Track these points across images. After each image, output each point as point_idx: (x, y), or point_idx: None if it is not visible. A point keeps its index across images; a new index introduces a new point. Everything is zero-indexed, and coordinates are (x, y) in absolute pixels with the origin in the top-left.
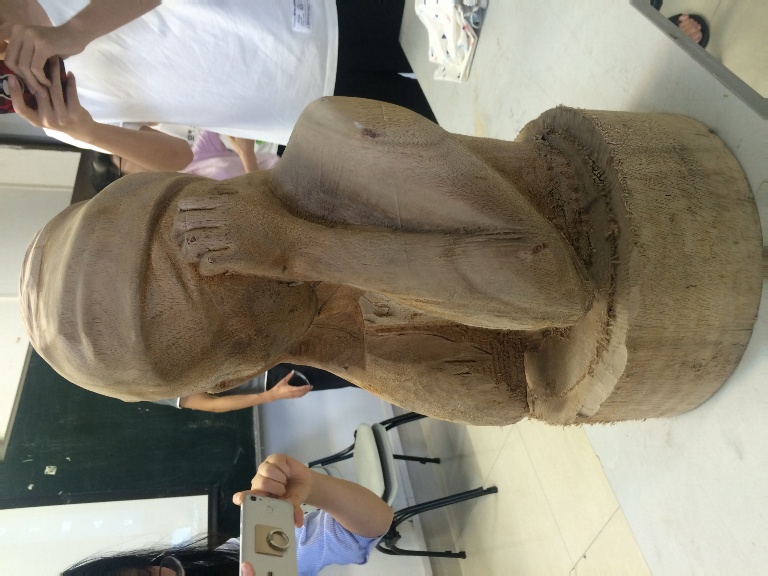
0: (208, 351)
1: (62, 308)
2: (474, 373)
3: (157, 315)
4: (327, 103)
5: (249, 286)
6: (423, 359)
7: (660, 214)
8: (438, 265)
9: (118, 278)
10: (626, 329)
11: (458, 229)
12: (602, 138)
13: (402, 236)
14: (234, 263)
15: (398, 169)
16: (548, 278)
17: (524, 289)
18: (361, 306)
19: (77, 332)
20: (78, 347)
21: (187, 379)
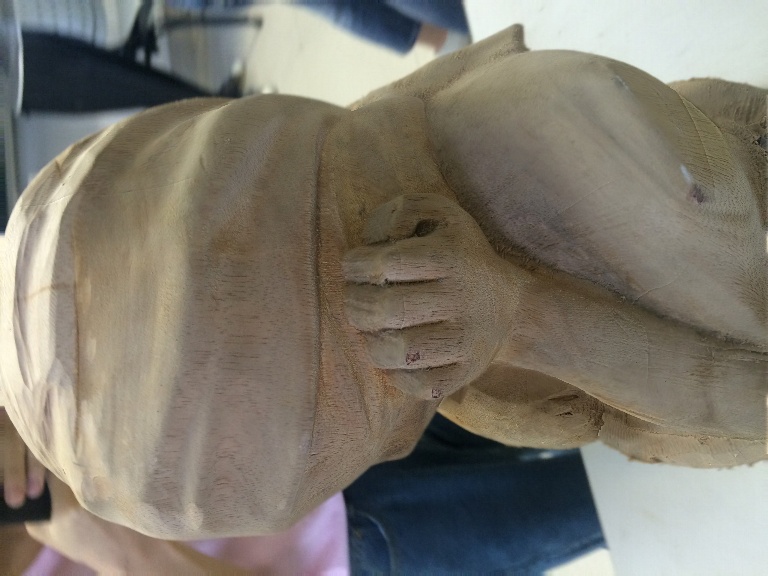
0: None
1: (157, 464)
2: (575, 413)
3: (319, 462)
4: (630, 98)
5: None
6: (530, 397)
7: None
8: (686, 385)
9: (272, 414)
10: None
11: (718, 332)
12: None
13: (644, 324)
14: None
15: (703, 252)
16: None
17: (760, 423)
18: None
19: (178, 497)
20: (173, 515)
21: None
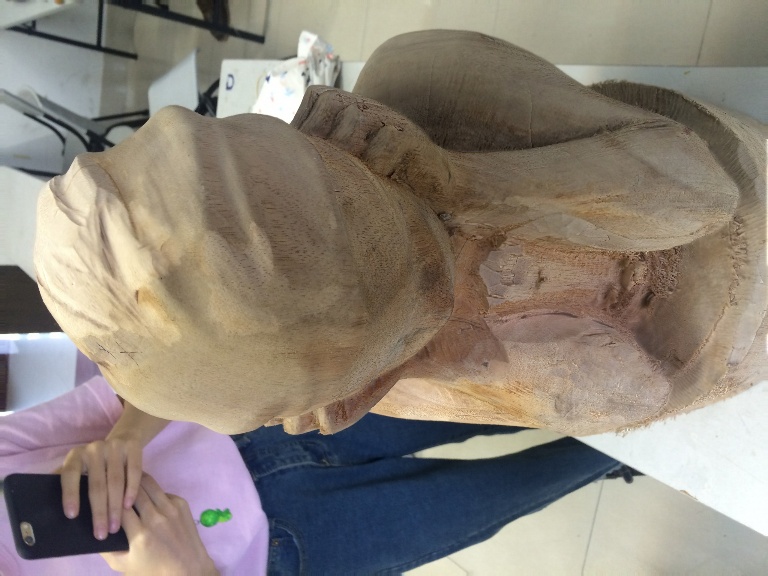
0: (405, 273)
1: (205, 190)
2: (617, 342)
3: (347, 202)
4: None
5: (414, 200)
6: (563, 335)
7: (733, 123)
8: (610, 154)
9: (280, 151)
10: (767, 221)
11: (600, 129)
12: (640, 85)
13: None
14: (419, 140)
15: (527, 70)
16: (708, 157)
17: (697, 167)
18: (483, 278)
19: (238, 225)
20: (243, 251)
21: (383, 323)
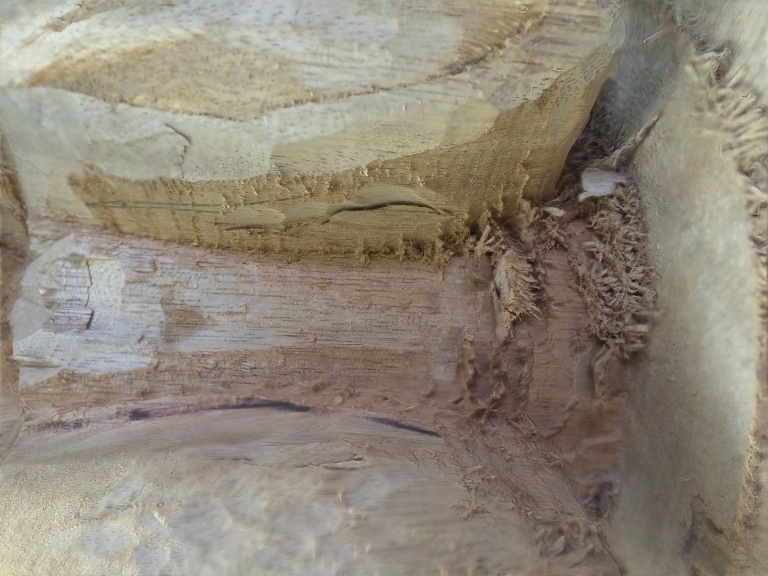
0: None
1: None
2: (373, 457)
3: None
4: None
5: None
6: (189, 444)
7: None
8: None
9: None
10: None
11: None
12: None
13: None
14: None
15: None
16: None
17: None
18: (15, 325)
19: None
20: None
21: None
